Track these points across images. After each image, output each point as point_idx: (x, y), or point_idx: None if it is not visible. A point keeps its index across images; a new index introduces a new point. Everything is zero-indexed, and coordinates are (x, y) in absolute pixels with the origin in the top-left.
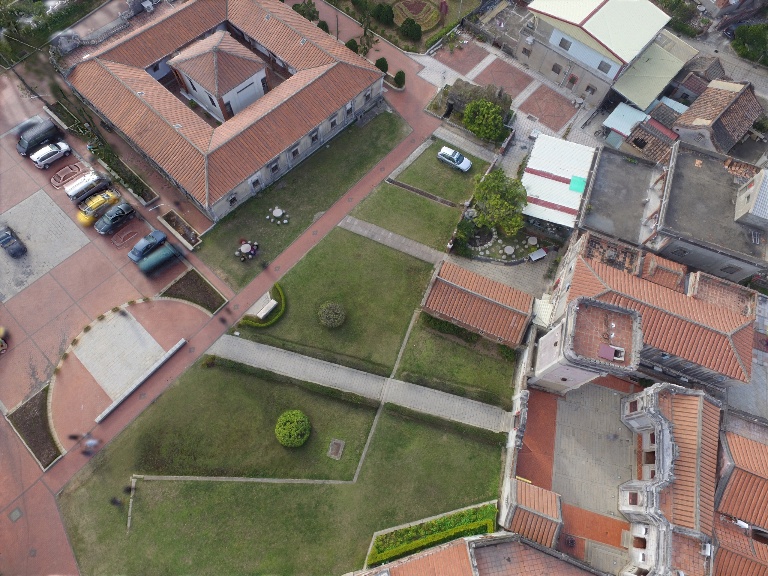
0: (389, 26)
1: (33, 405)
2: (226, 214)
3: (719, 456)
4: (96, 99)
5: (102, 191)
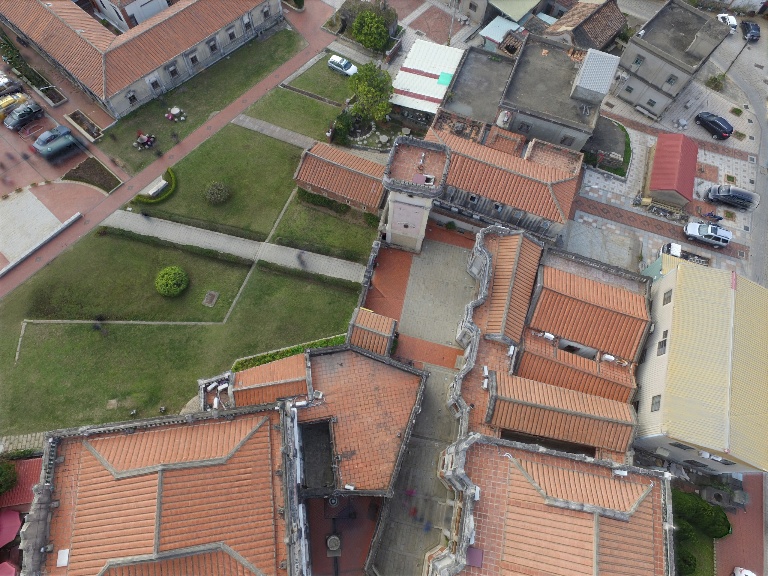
0: None
1: None
2: (128, 113)
3: (535, 283)
4: (8, 11)
5: (13, 93)
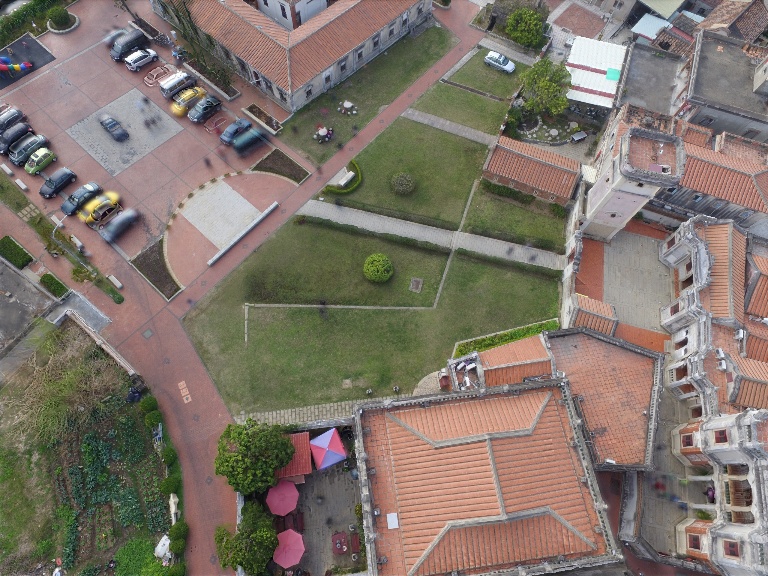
0: None
1: (153, 251)
2: (302, 106)
3: (747, 271)
4: (182, 8)
5: (191, 87)
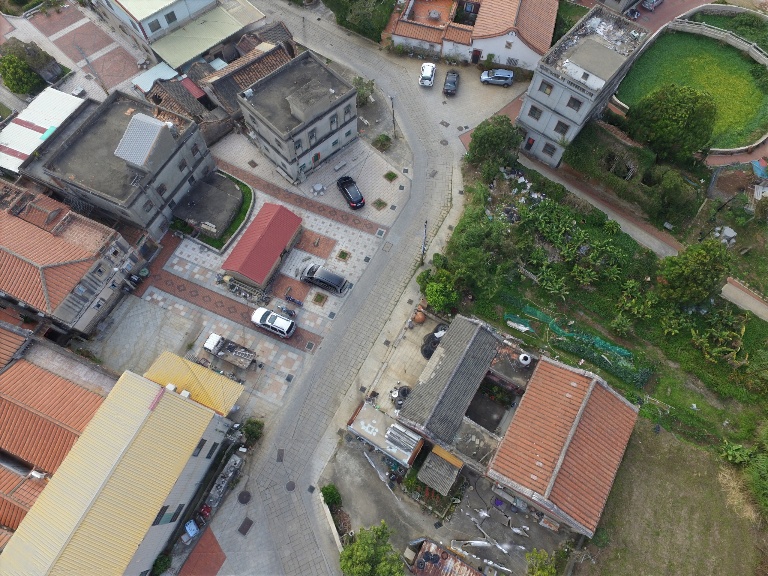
0: None
1: None
2: None
3: None
4: None
5: None
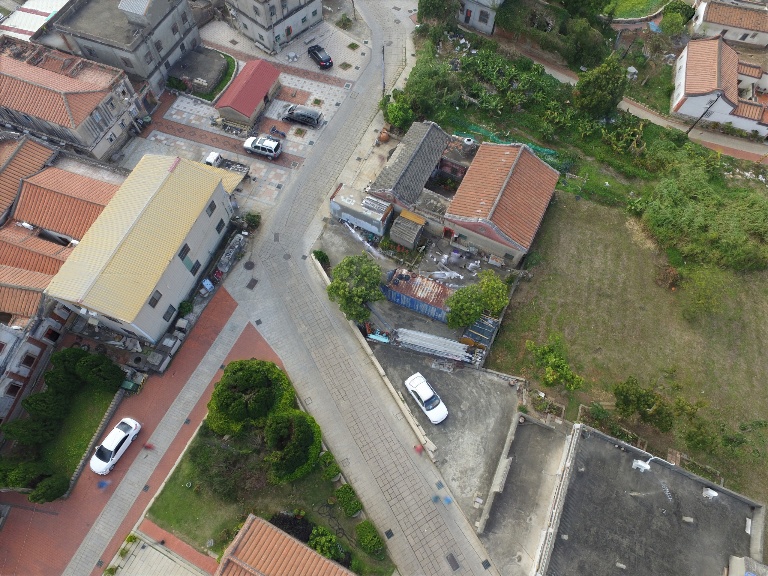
0: None
1: None
2: None
3: None
4: None
5: None
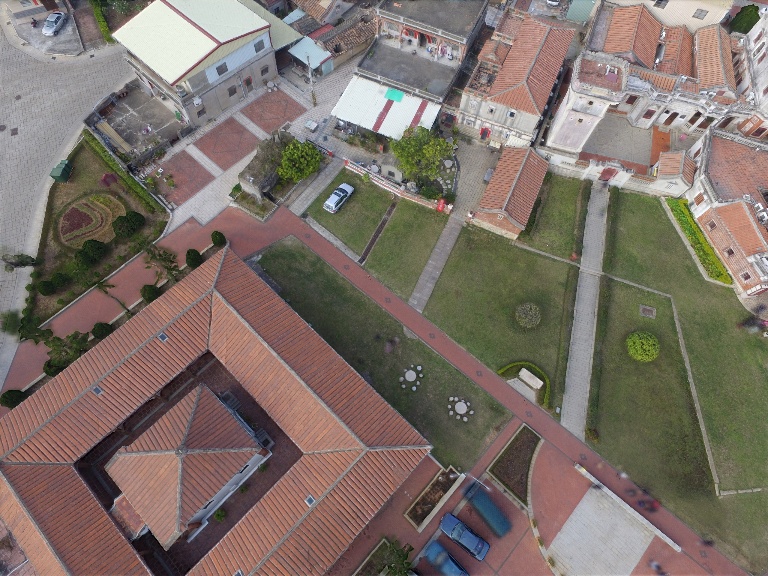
0: (107, 252)
1: None
2: None
3: None
4: None
5: None
